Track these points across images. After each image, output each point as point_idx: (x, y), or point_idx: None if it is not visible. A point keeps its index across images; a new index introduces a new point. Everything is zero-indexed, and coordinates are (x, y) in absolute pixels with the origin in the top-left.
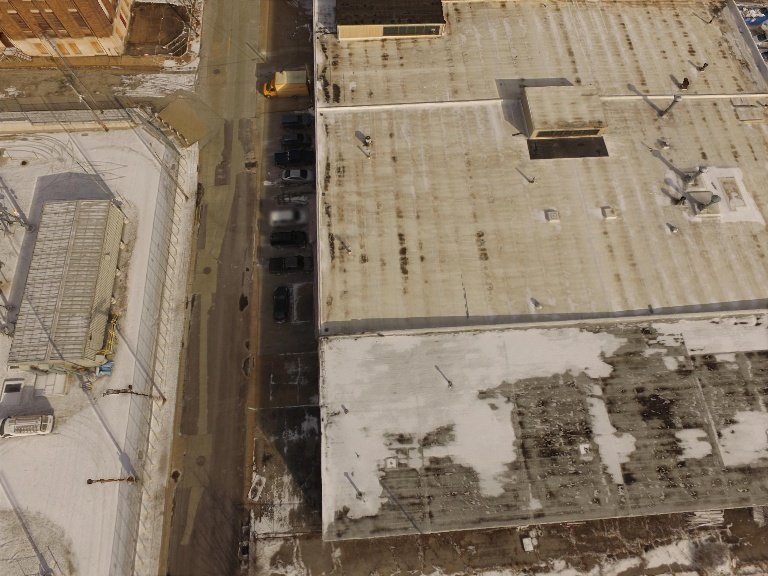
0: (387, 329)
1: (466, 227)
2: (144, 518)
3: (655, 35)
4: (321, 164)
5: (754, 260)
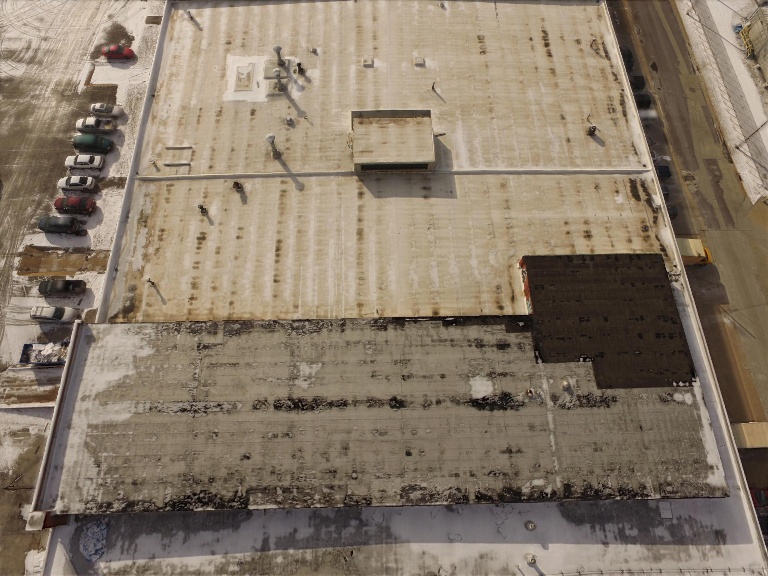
0: None
1: (495, 59)
2: None
3: (238, 264)
4: (632, 115)
5: (254, 30)
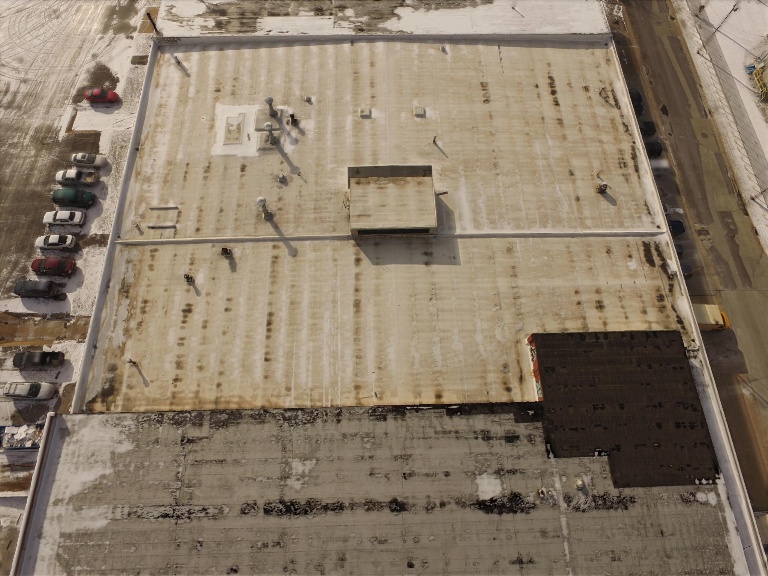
0: (561, 42)
1: (499, 108)
2: (683, 1)
3: (227, 340)
4: (644, 170)
5: (245, 76)
